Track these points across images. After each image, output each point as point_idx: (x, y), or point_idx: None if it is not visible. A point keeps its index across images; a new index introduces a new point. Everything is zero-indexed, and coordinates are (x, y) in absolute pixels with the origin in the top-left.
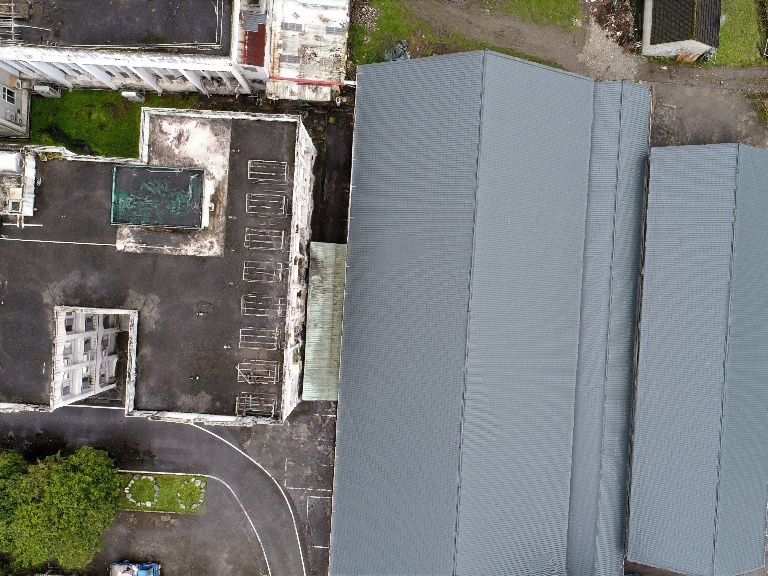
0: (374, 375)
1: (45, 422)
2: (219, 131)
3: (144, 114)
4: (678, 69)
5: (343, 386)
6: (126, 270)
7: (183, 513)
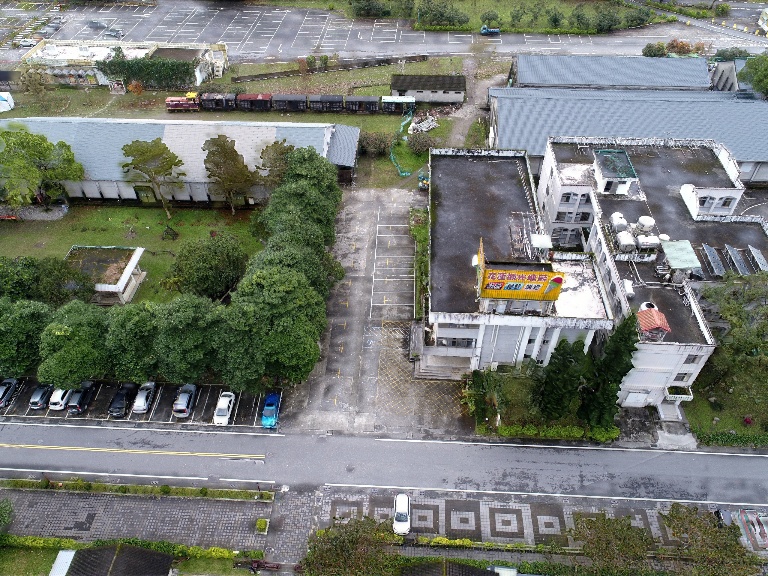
0: None
1: None
2: (562, 167)
3: None
4: (468, 96)
5: None
6: (658, 197)
7: None
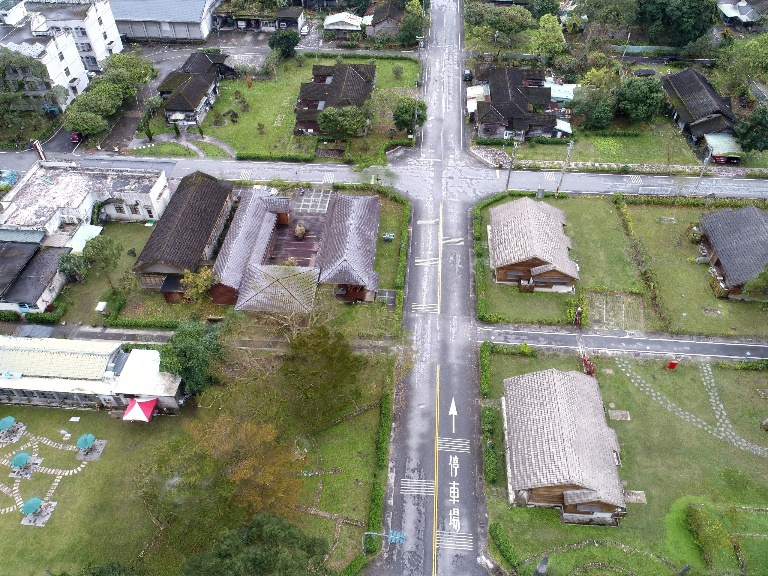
0: (111, 8)
1: None
2: None
3: None
4: None
5: (114, 18)
6: None
7: None
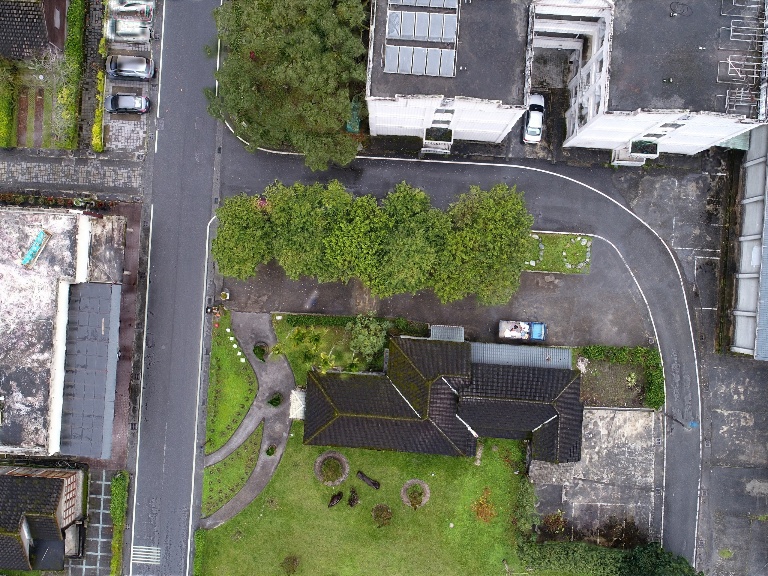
0: None
1: (426, 179)
2: None
3: None
4: None
5: None
6: None
7: (567, 273)
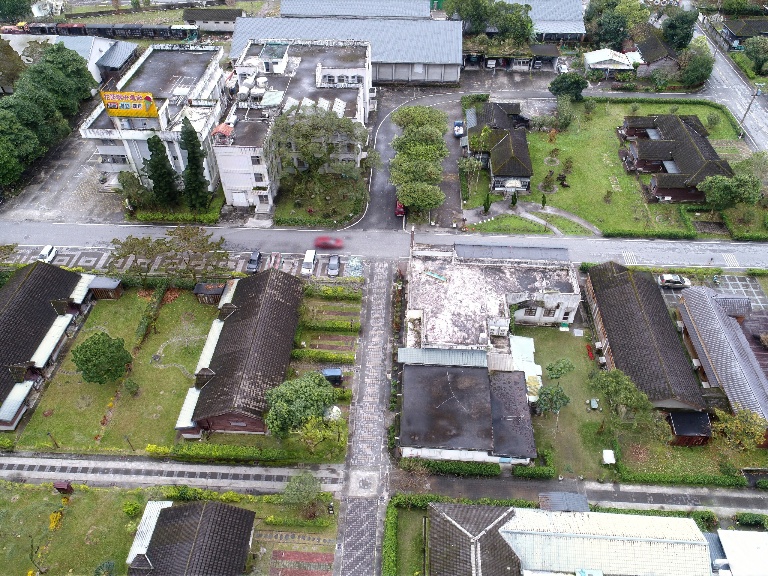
0: None
1: (383, 159)
2: None
3: (237, 66)
4: None
5: None
6: None
7: None
